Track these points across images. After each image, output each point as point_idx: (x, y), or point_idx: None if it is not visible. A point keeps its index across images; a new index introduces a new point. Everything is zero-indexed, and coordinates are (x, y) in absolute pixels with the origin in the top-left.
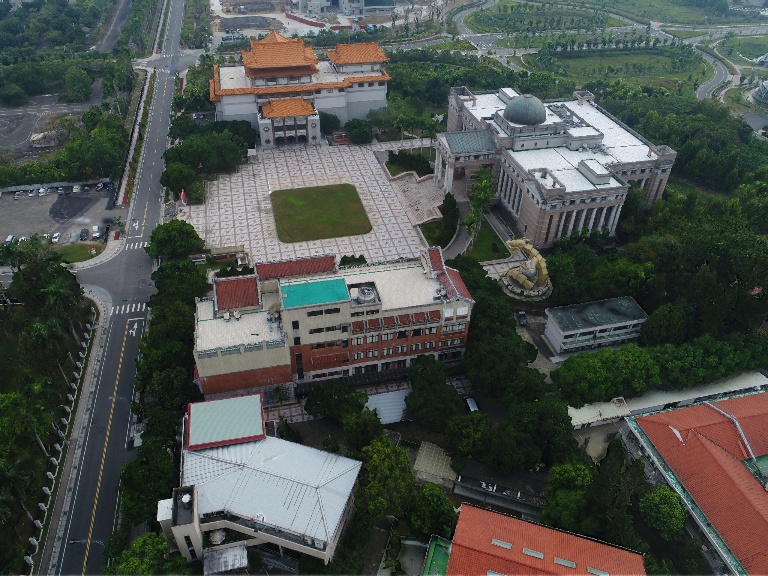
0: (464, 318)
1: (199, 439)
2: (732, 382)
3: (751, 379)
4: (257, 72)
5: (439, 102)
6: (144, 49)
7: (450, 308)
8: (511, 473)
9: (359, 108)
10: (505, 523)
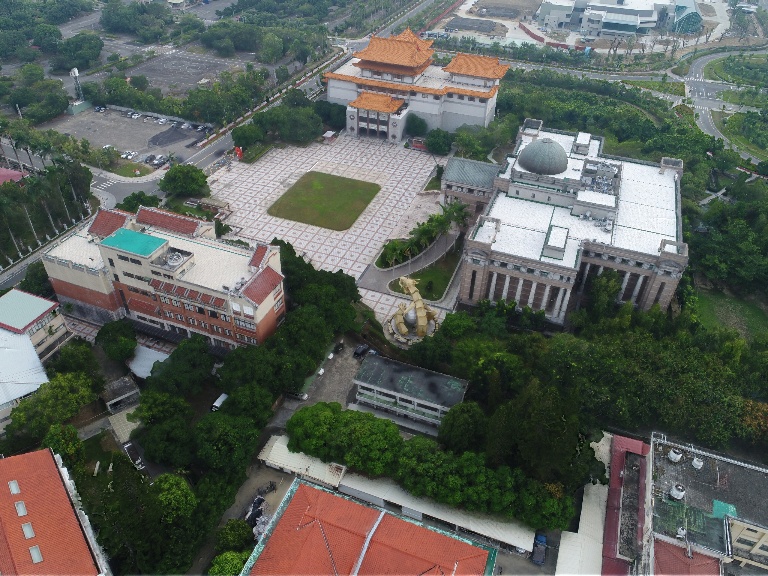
0: (252, 319)
1: None
2: (486, 523)
3: (512, 533)
4: (365, 63)
5: None
6: (362, 32)
7: (236, 302)
8: (159, 463)
9: (456, 120)
10: (49, 479)
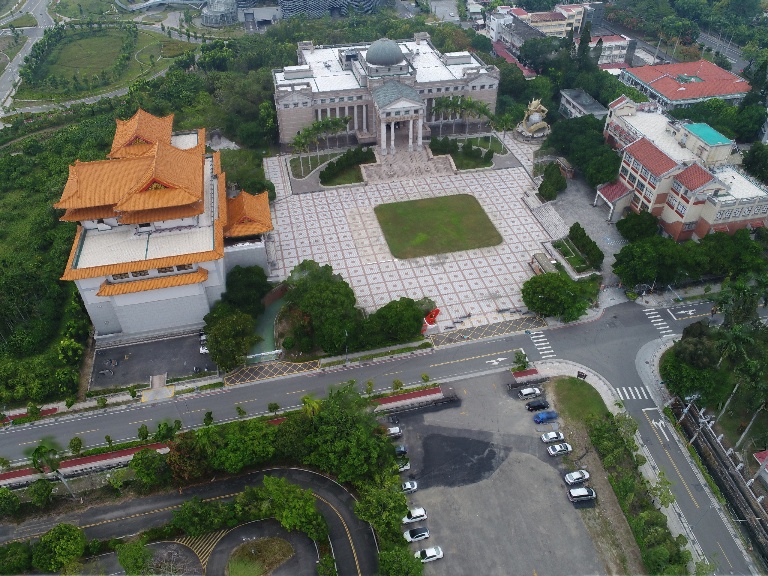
0: None
1: None
2: None
3: None
4: None
5: None
6: None
7: None
8: None
9: None
10: None
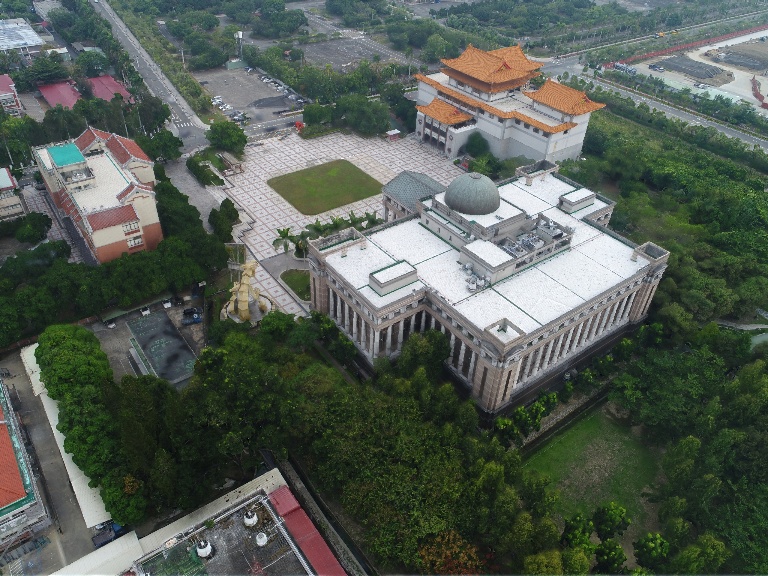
0: None
1: None
2: None
3: (96, 505)
4: (452, 71)
5: (623, 196)
6: (553, 52)
7: None
8: None
9: (520, 150)
10: None
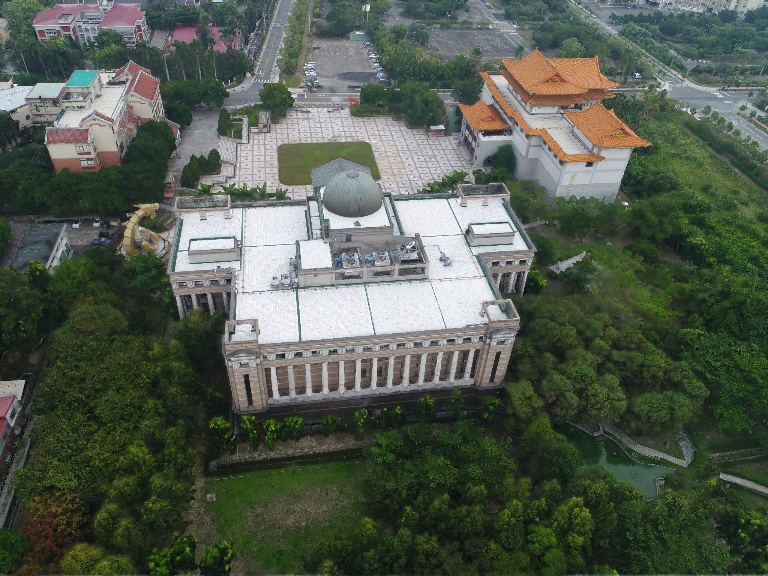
0: None
1: None
2: None
3: None
4: None
5: None
6: (725, 82)
7: None
8: None
9: (542, 174)
10: None
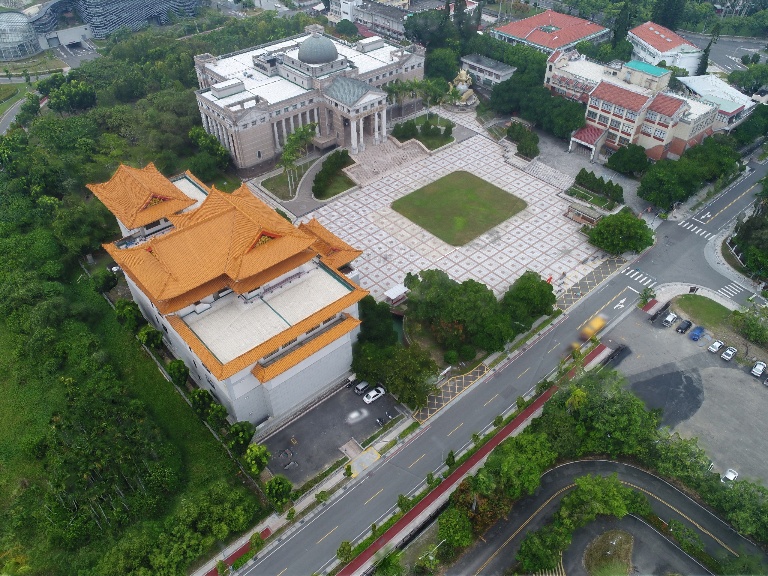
0: None
1: (738, 104)
2: None
3: None
4: None
5: None
6: None
7: None
8: None
9: None
10: None
